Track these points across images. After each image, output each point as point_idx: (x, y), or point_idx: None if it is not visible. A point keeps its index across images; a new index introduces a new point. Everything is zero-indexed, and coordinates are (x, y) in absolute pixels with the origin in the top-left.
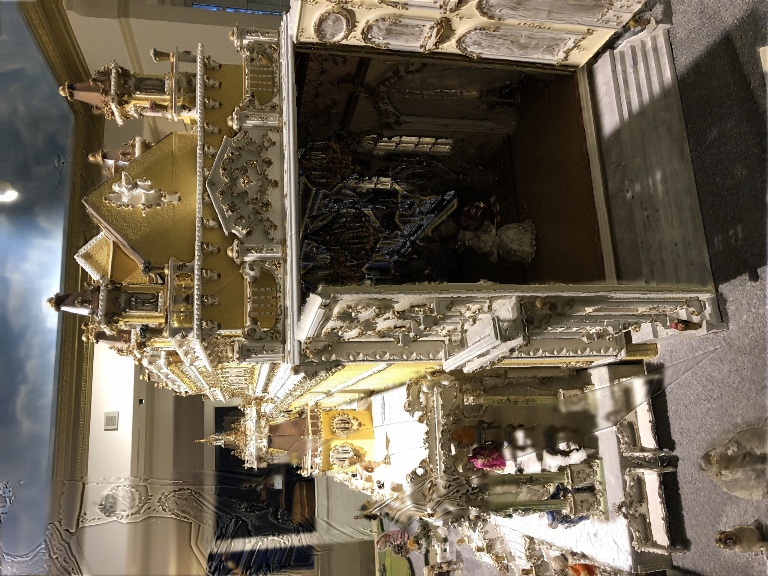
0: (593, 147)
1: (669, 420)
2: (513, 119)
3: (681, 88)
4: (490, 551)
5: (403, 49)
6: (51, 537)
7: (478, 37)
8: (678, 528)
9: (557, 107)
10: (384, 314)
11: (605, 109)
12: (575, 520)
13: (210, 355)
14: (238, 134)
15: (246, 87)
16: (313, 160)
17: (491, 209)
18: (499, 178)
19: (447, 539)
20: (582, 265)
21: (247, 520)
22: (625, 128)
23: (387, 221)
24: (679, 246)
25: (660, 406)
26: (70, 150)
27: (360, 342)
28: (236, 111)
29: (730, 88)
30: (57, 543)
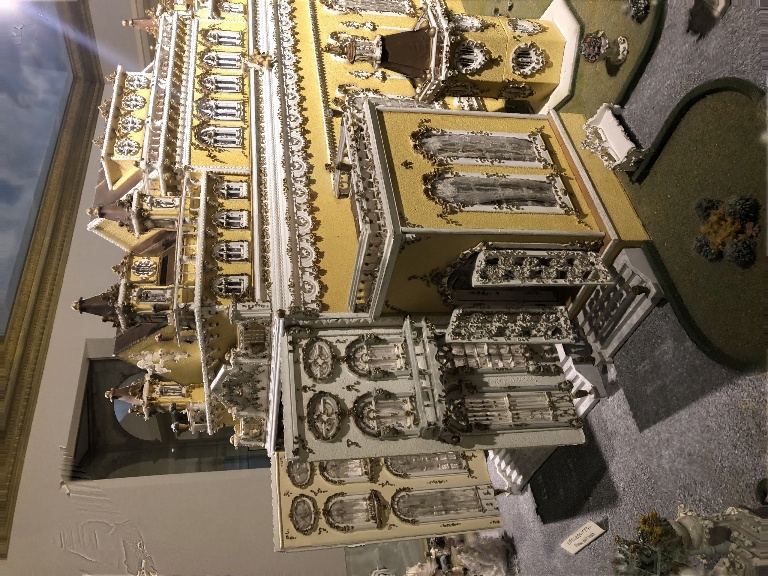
0: None
1: None
2: None
3: None
4: None
5: None
6: None
7: None
8: None
9: None
10: None
11: None
12: None
13: None
14: None
15: (241, 347)
16: None
17: None
18: None
19: None
20: None
21: None
22: None
23: None
24: (526, 456)
25: None
26: (24, 15)
27: None
28: (232, 363)
29: None
30: None
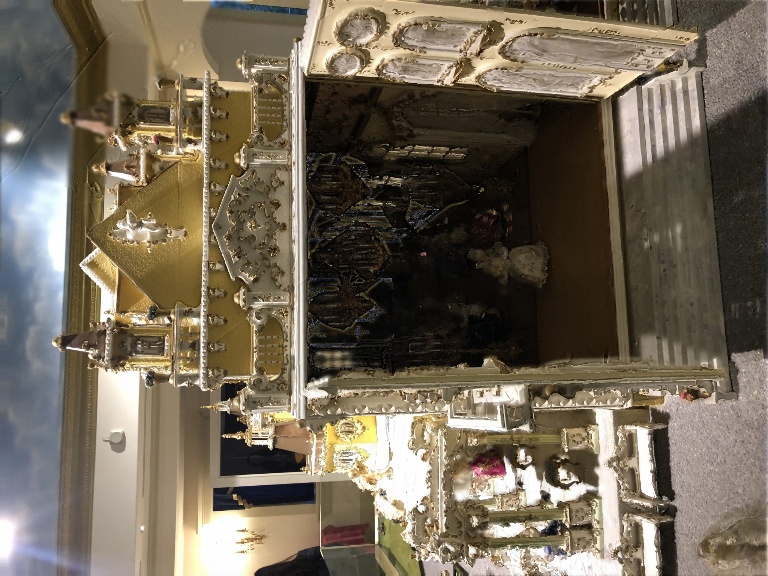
0: (613, 186)
1: (670, 470)
2: (531, 134)
3: (710, 139)
4: None
5: (419, 83)
6: None
7: (499, 75)
8: (671, 575)
9: (578, 134)
10: None
11: (628, 147)
12: None
13: None
14: (246, 173)
15: (254, 122)
16: (323, 184)
17: (504, 217)
18: (514, 189)
19: None
20: (594, 304)
21: None
22: (648, 173)
23: (397, 219)
24: (694, 306)
25: (663, 454)
26: None
27: None
28: (244, 149)
29: (762, 153)
30: None
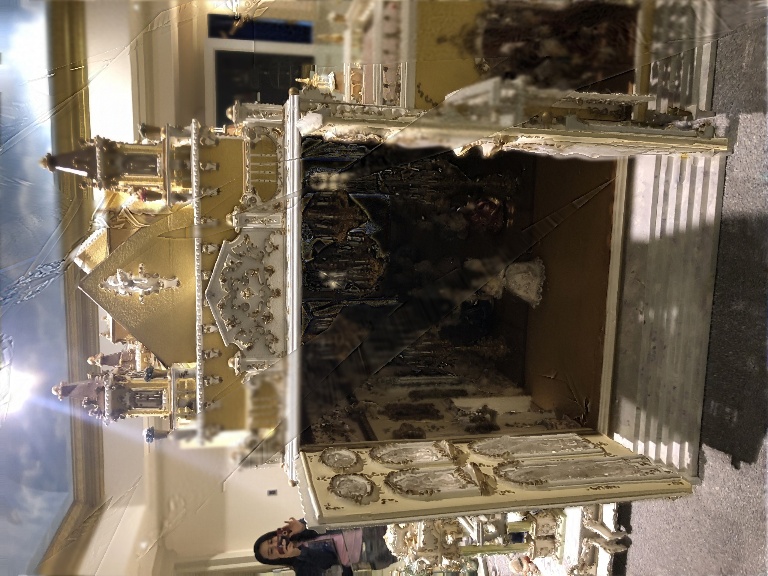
0: (617, 246)
1: (631, 509)
2: None
3: (722, 231)
4: None
5: None
6: None
7: None
8: None
9: (590, 171)
10: None
11: (638, 210)
12: None
13: None
14: (238, 237)
15: (247, 182)
16: None
17: (505, 206)
18: None
19: None
20: (582, 349)
21: None
22: (654, 246)
23: (396, 185)
24: (677, 389)
25: None
26: None
27: None
28: None
29: None
30: None
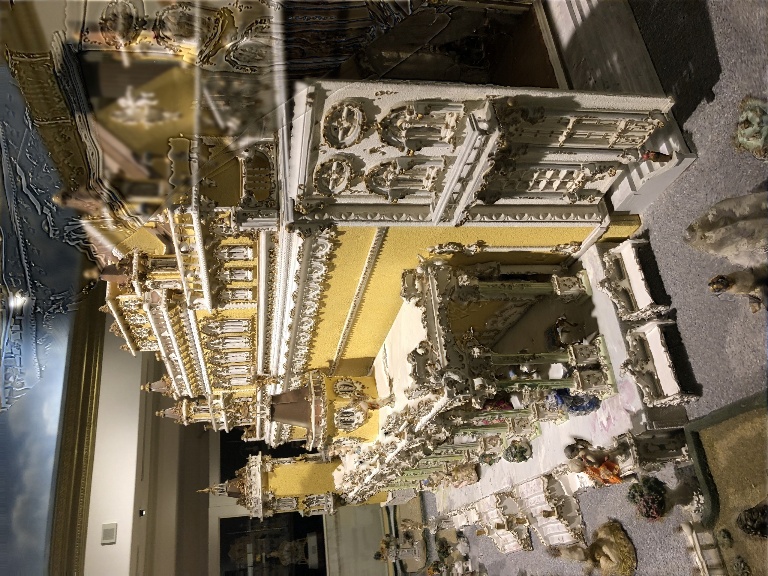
0: (555, 58)
1: (661, 279)
2: (485, 78)
3: None
4: (511, 527)
5: None
6: (56, 52)
7: None
8: (687, 379)
9: (521, 45)
10: (368, 128)
11: (561, 25)
12: (585, 405)
13: (209, 267)
14: None
15: None
16: None
17: None
18: None
19: (468, 556)
20: None
21: (232, 9)
22: (580, 31)
23: None
24: None
25: (651, 271)
26: None
27: (351, 205)
28: None
29: None
30: (61, 59)
